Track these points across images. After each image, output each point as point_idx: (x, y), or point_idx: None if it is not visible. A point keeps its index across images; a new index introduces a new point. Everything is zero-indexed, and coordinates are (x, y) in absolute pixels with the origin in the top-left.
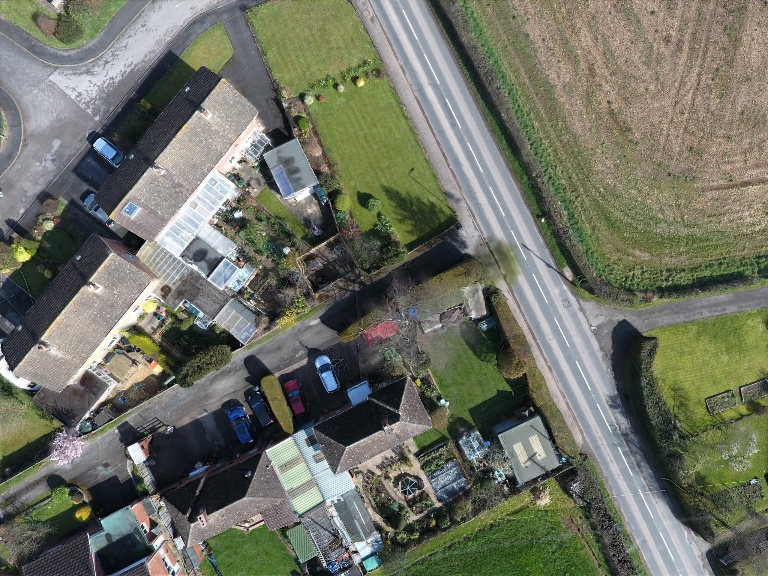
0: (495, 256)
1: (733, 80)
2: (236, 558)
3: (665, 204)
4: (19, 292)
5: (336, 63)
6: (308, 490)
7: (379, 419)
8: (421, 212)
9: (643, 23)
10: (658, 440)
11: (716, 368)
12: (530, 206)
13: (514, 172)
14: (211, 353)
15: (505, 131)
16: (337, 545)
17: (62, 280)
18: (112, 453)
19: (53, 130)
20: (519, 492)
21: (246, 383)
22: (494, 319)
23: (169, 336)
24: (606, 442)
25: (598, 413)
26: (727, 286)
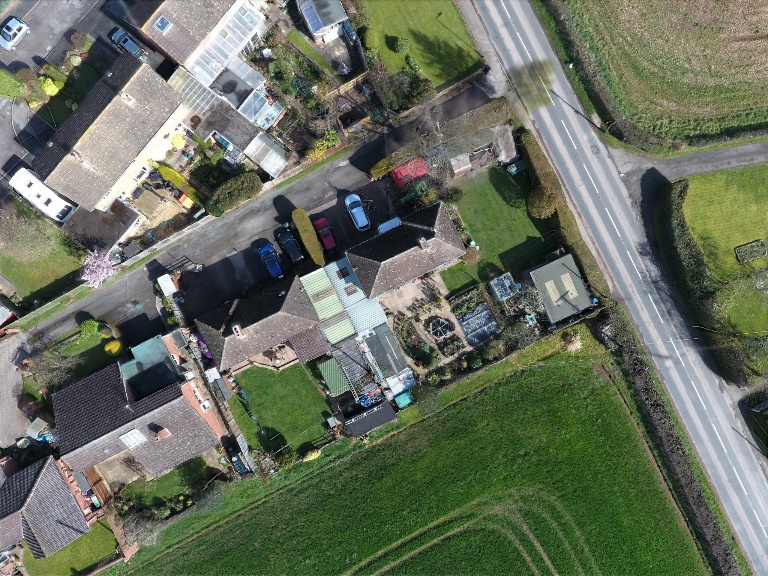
0: (523, 102)
1: None
2: (266, 398)
3: (692, 54)
4: (46, 128)
5: None
6: (340, 321)
7: (414, 238)
8: (449, 56)
9: None
10: (690, 282)
11: (745, 217)
12: (558, 52)
13: (542, 18)
14: (242, 178)
15: None
16: (369, 380)
17: (93, 96)
18: (141, 291)
19: None
20: (551, 333)
21: (275, 222)
22: (523, 162)
23: (198, 174)
24: (636, 289)
25: (628, 260)
26: (755, 132)
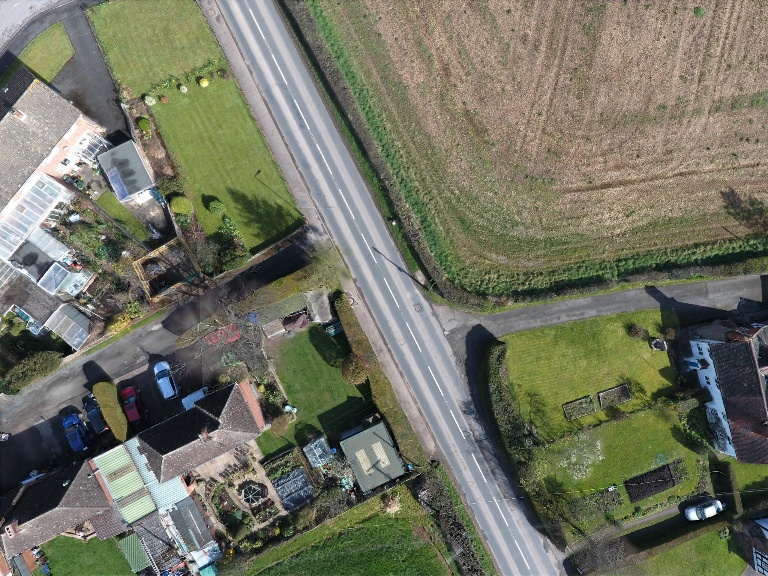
0: (345, 260)
1: (592, 80)
2: (73, 568)
3: (522, 206)
4: None
5: (180, 63)
6: (139, 499)
7: (200, 427)
8: (268, 215)
9: (499, 22)
10: (507, 447)
11: (574, 373)
12: (381, 209)
13: (364, 174)
14: (35, 359)
15: (354, 132)
16: (171, 555)
17: None
18: None
19: None
20: (364, 500)
21: (84, 389)
22: (341, 324)
23: (5, 342)
24: (459, 449)
25: (451, 419)
26: (582, 290)
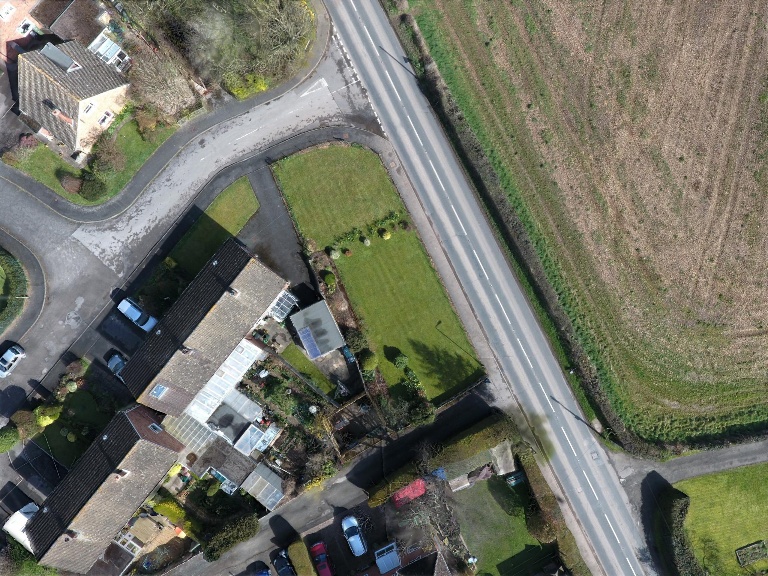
0: (523, 409)
1: (763, 226)
2: None
3: (694, 352)
4: (41, 454)
5: (362, 215)
6: None
7: None
8: (448, 365)
9: (672, 170)
10: None
11: (746, 518)
12: (558, 358)
13: (542, 323)
14: (238, 527)
15: (533, 283)
16: None
17: (88, 461)
18: None
19: (76, 288)
20: None
21: (271, 544)
22: (522, 475)
23: (193, 497)
24: None
25: (627, 567)
26: (758, 438)
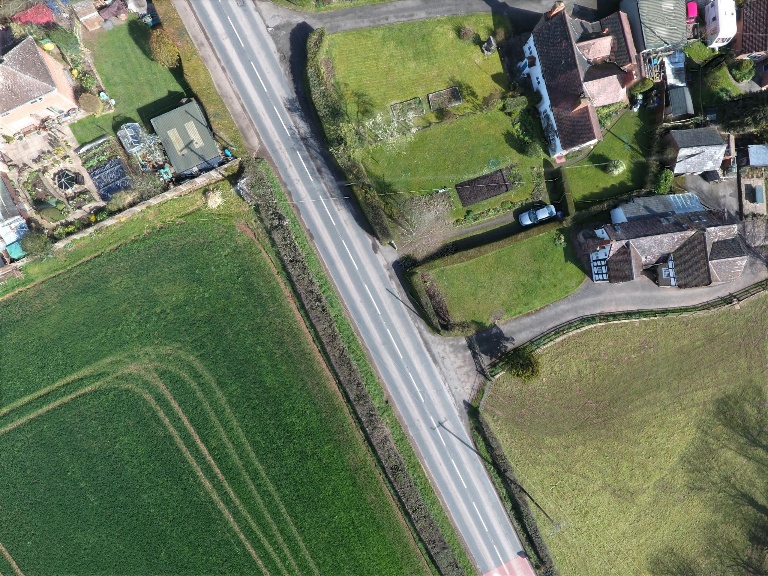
0: None
1: None
2: None
3: None
4: None
5: None
6: None
7: None
8: None
9: None
10: (326, 133)
11: (403, 74)
12: None
13: None
14: None
15: None
16: None
17: None
18: None
19: None
20: (179, 185)
21: None
22: None
23: None
24: (284, 146)
25: (275, 116)
26: None
